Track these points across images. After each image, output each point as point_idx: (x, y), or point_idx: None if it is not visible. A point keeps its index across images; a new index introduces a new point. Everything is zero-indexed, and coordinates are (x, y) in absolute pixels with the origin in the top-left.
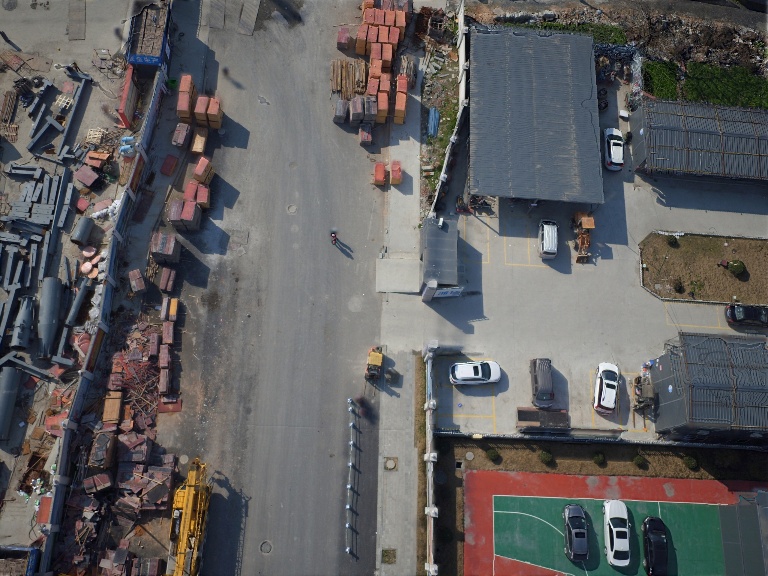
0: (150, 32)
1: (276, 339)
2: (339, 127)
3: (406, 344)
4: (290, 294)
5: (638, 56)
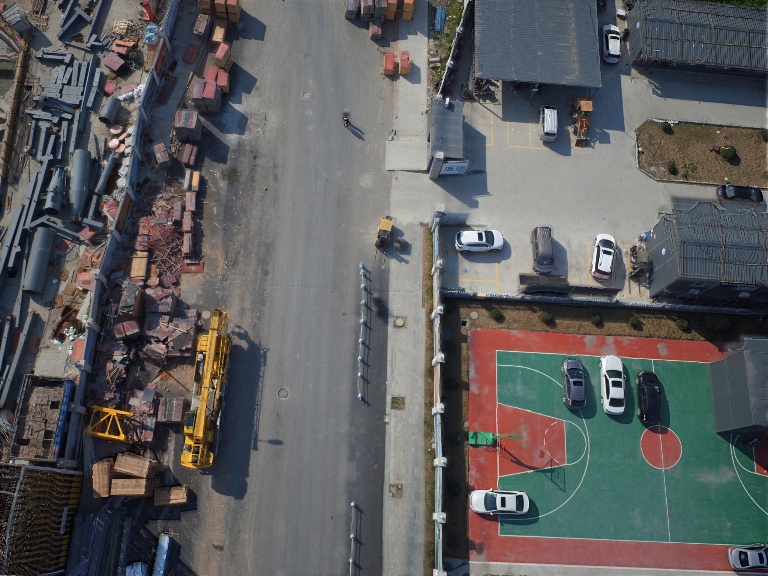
0: None
1: (292, 210)
2: (351, 23)
3: (414, 217)
4: (305, 171)
5: None
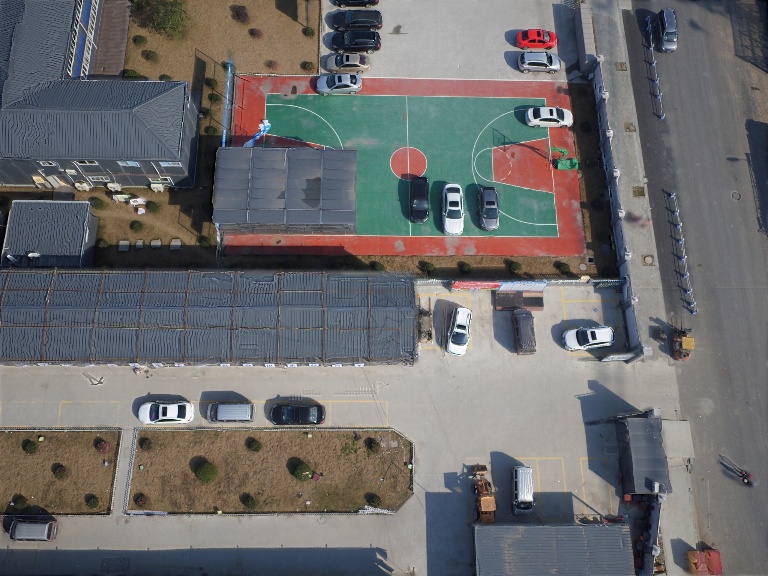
0: None
1: None
2: None
3: (651, 368)
4: None
5: None
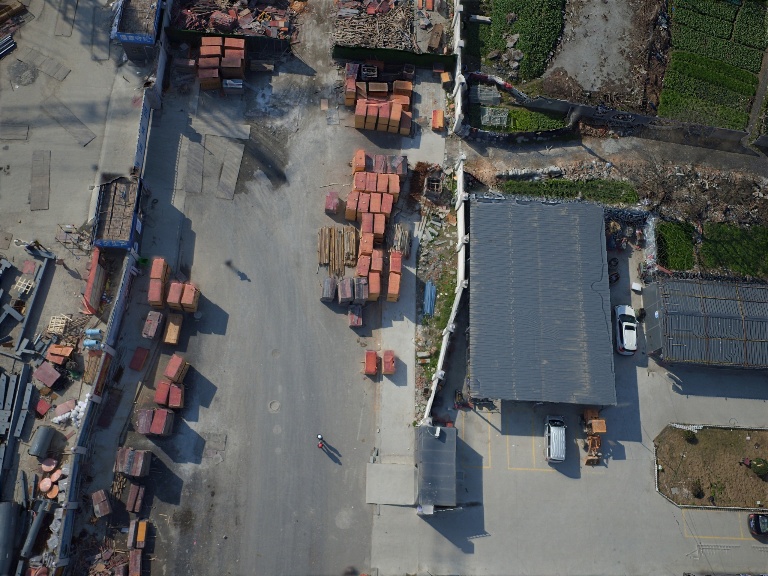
0: (119, 211)
1: (255, 565)
2: (327, 306)
3: (399, 567)
4: (271, 509)
5: (651, 217)
